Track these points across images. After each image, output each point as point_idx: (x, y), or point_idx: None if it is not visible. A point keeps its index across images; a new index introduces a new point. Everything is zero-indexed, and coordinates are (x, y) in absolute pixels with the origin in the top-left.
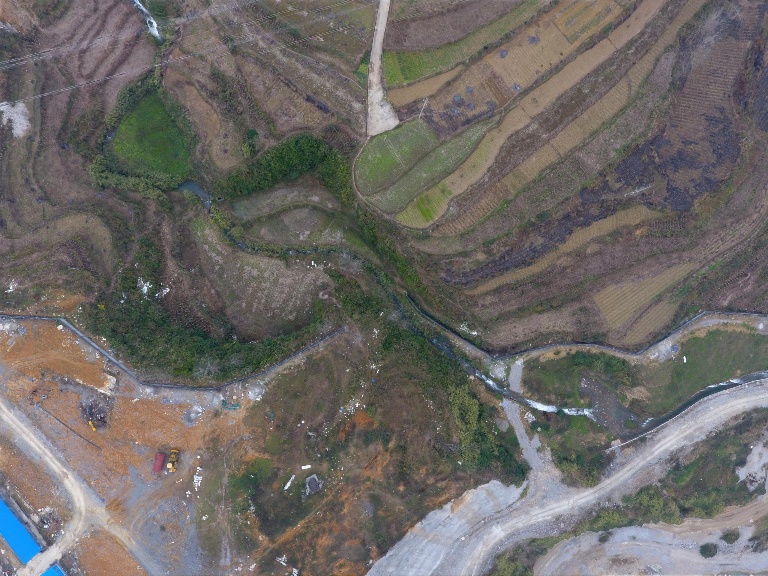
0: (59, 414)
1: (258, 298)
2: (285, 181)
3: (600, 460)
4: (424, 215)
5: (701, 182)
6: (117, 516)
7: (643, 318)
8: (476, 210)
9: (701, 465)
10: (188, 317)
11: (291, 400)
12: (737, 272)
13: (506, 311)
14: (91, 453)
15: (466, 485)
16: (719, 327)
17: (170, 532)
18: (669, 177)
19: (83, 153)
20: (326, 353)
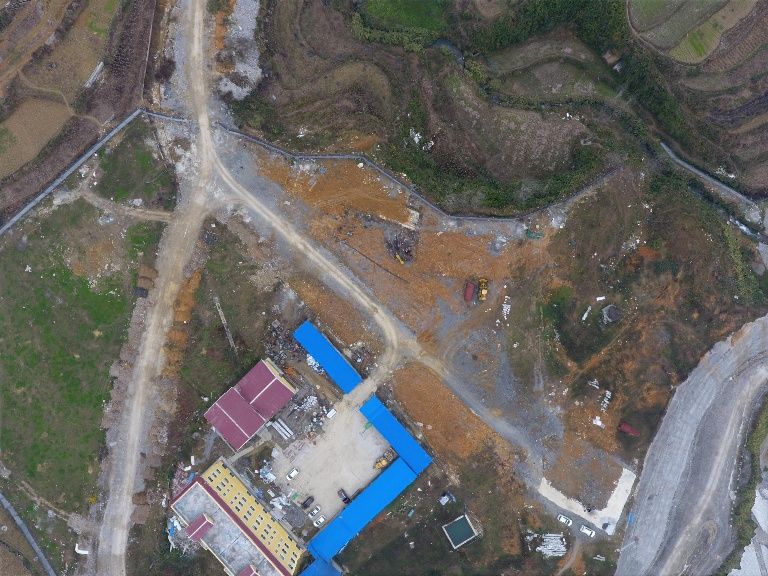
0: (365, 250)
1: (517, 150)
2: (538, 34)
3: None
4: (697, 50)
5: None
6: (429, 347)
7: None
8: (744, 45)
9: None
10: (456, 167)
11: (588, 230)
12: None
13: (766, 151)
14: (399, 287)
15: (744, 318)
16: None
17: (482, 361)
18: None
19: (343, 10)
20: (611, 188)
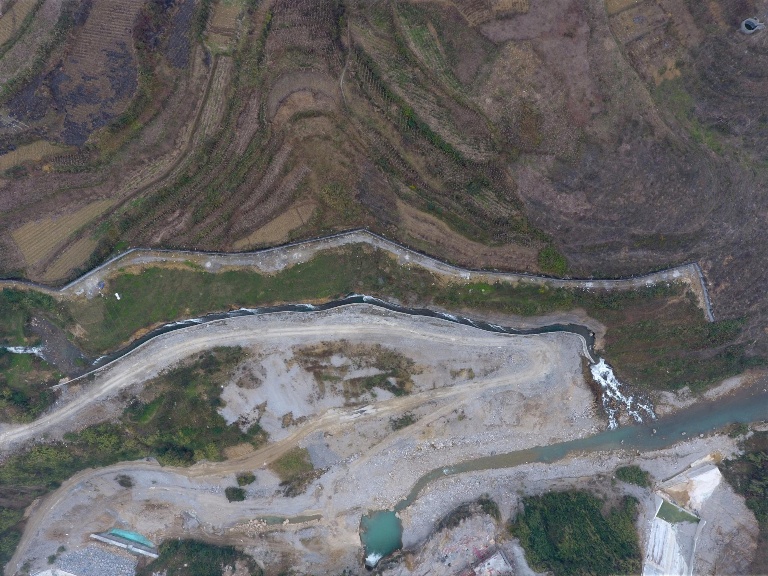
0: None
1: None
2: None
3: (47, 398)
4: None
5: (99, 117)
6: None
7: (63, 254)
8: None
9: (163, 404)
10: None
11: None
12: (163, 209)
13: None
14: None
15: None
16: (156, 265)
17: None
18: (67, 112)
19: None
20: None
